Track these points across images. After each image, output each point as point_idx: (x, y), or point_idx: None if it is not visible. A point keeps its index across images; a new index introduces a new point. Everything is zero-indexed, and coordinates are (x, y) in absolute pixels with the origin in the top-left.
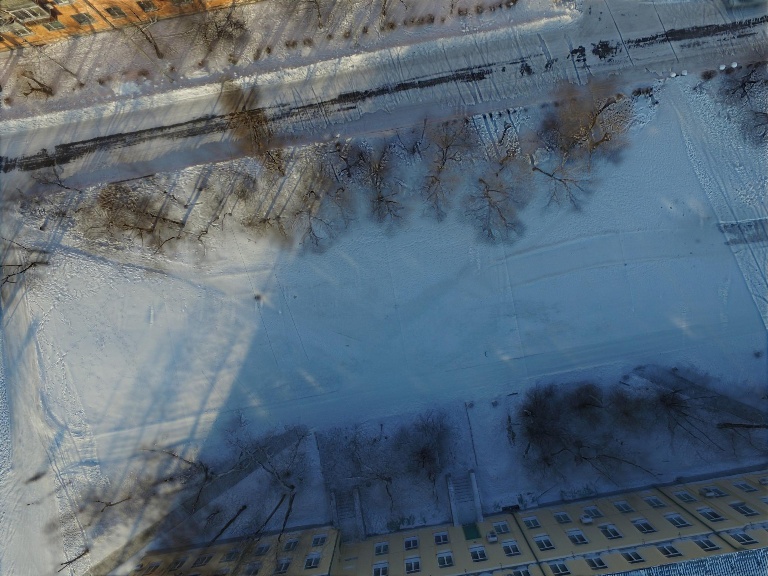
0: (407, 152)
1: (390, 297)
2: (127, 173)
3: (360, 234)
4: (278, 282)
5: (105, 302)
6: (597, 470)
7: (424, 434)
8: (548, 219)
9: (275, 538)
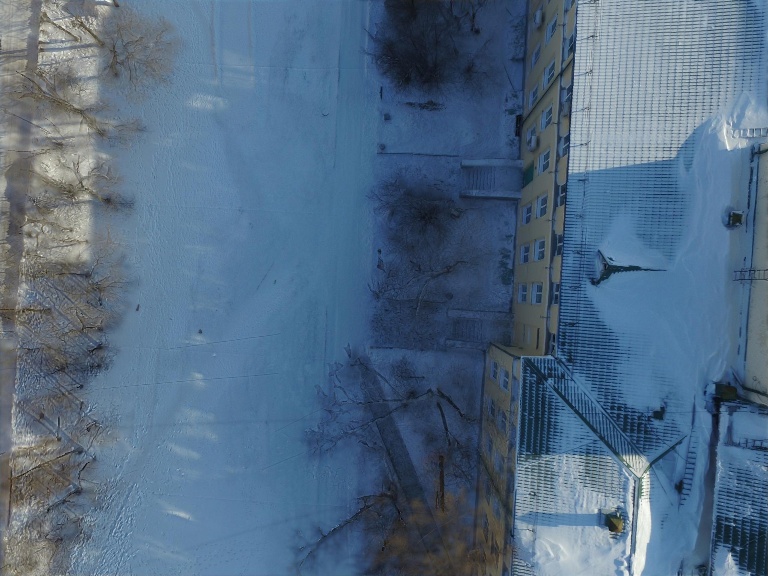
0: (54, 150)
1: (228, 215)
2: (3, 502)
3: (144, 234)
4: (178, 348)
5: (149, 569)
6: (490, 4)
7: (397, 208)
8: (182, 3)
9: (484, 428)
